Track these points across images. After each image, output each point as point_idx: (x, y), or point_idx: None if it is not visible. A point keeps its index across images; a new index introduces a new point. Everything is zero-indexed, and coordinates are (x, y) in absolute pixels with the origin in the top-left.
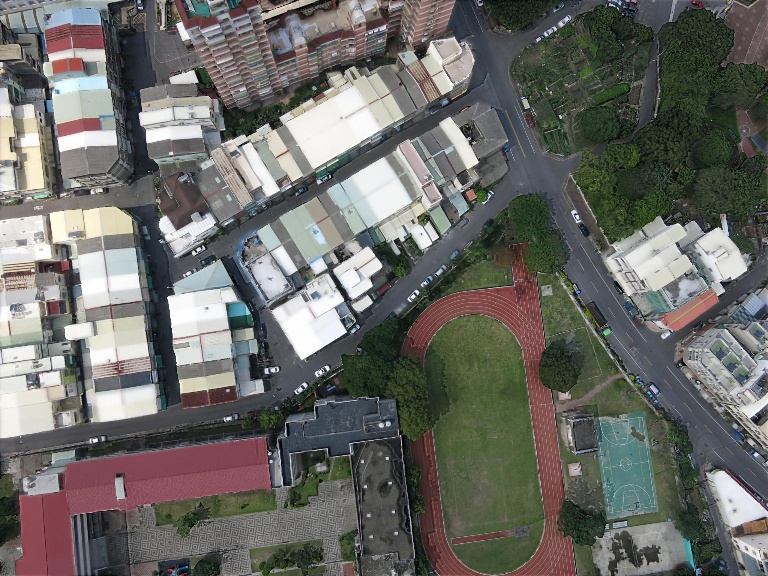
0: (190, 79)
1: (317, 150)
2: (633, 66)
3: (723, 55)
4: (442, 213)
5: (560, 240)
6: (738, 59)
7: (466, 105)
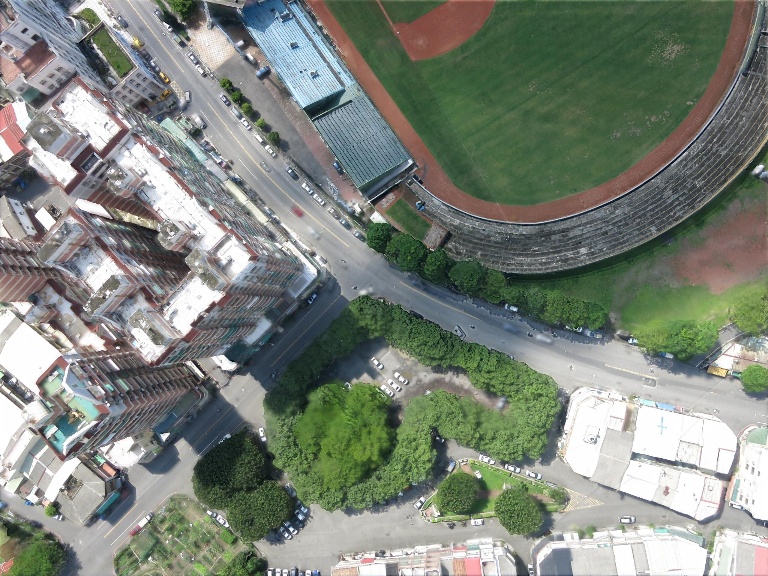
0: (48, 224)
1: (10, 358)
2: None
3: None
4: (19, 482)
5: None
6: None
7: None
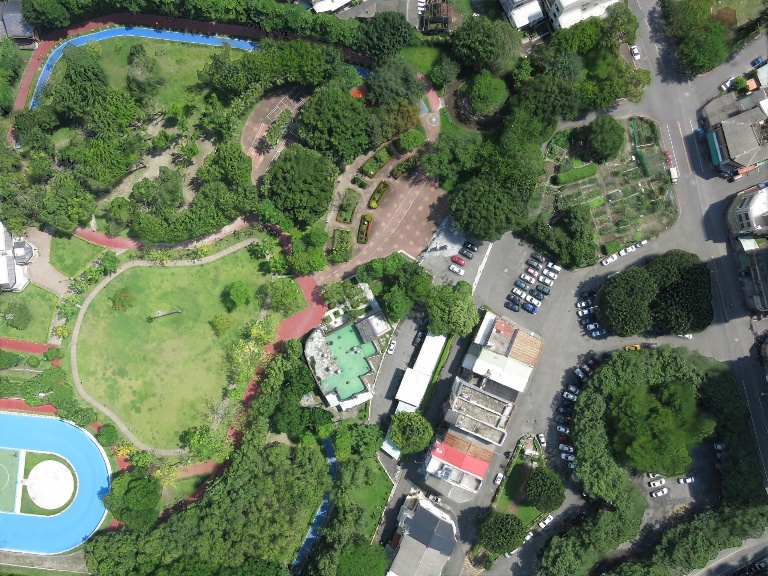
0: None
1: None
2: (542, 203)
3: (469, 183)
4: None
5: (672, 21)
6: (425, 196)
7: (734, 184)
